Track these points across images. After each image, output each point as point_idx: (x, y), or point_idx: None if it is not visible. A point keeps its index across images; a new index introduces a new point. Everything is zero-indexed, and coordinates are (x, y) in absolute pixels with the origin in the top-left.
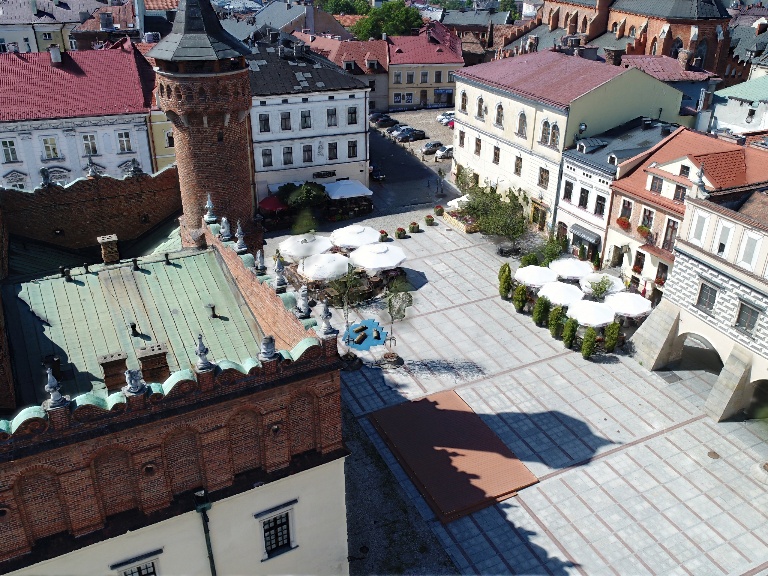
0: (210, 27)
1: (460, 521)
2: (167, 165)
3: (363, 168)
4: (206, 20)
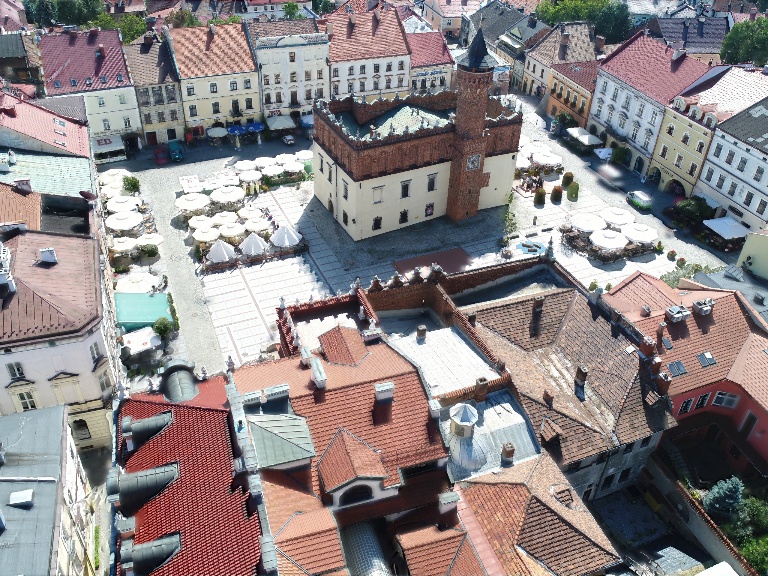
0: (472, 52)
1: (394, 267)
2: (662, 143)
3: (763, 227)
4: (472, 49)
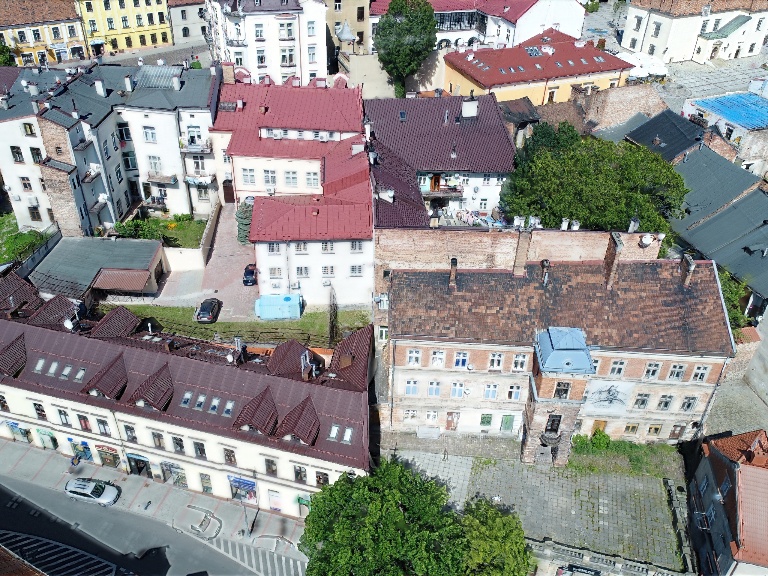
0: None
1: None
2: None
3: None
4: None
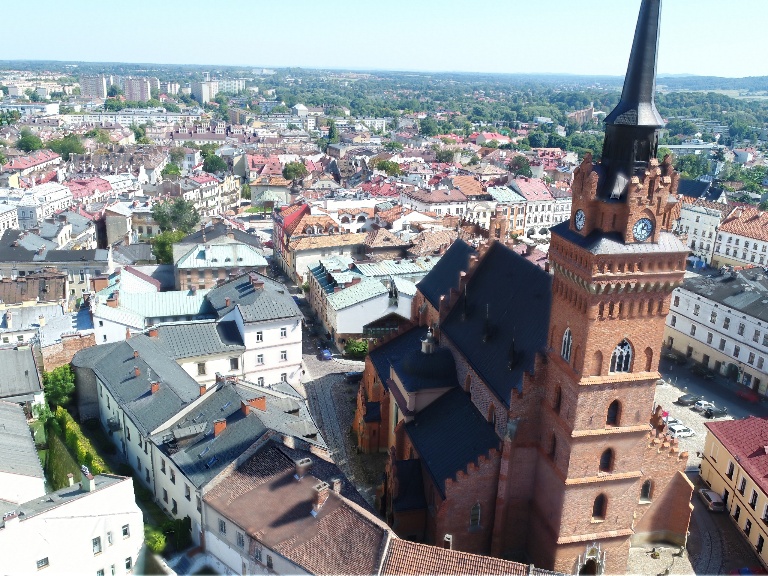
0: None
1: None
2: None
3: None
4: None
